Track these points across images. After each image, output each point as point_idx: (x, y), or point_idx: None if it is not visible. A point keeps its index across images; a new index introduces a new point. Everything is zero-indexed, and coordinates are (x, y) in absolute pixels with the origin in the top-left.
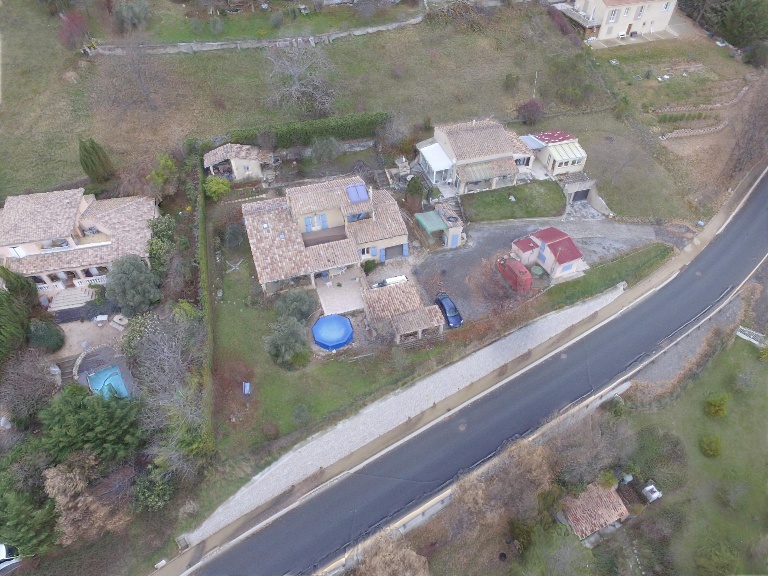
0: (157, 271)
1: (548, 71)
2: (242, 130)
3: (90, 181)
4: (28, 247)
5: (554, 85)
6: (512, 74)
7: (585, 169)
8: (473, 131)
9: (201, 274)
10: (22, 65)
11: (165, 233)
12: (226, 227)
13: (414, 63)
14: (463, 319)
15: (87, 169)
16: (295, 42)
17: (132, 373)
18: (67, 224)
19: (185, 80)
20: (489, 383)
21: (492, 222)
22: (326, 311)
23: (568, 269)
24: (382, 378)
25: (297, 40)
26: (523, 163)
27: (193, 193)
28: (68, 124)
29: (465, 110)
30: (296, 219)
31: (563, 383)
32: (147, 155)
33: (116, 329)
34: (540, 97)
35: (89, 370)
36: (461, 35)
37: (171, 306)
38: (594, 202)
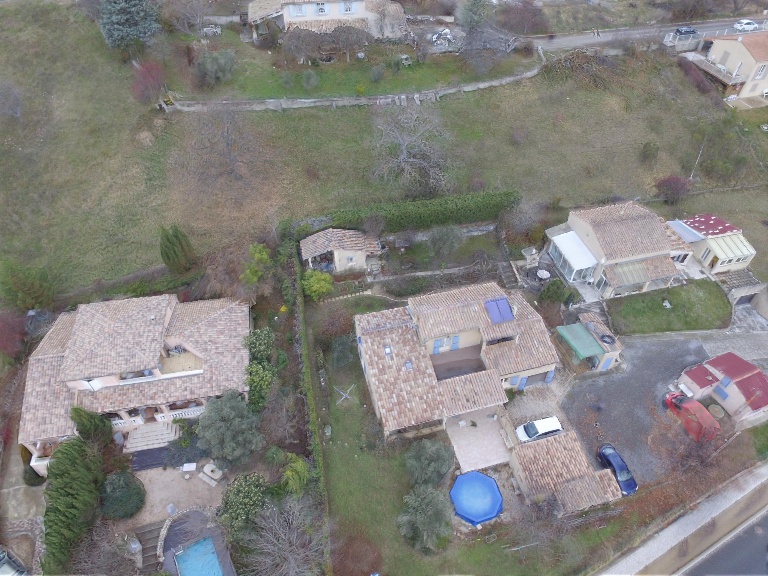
0: (256, 405)
1: (689, 138)
2: (344, 211)
3: (168, 270)
4: (105, 379)
5: (697, 155)
6: (648, 141)
7: (748, 265)
8: (623, 222)
9: (309, 411)
10: (91, 122)
11: (264, 353)
12: (329, 336)
13: (534, 126)
14: (637, 484)
15: (168, 261)
16: (398, 100)
17: (231, 555)
18: (152, 350)
19: (274, 144)
20: (668, 567)
21: (645, 335)
22: (463, 464)
23: (756, 411)
24: (546, 572)
25: (400, 97)
26: (677, 259)
27: (291, 293)
28: (142, 196)
29: (597, 185)
30: (425, 342)
31: (765, 573)
32: (232, 237)
33: (207, 483)
34: (683, 170)
35: (176, 547)
36: (583, 91)
37: (274, 455)
38: (762, 309)
